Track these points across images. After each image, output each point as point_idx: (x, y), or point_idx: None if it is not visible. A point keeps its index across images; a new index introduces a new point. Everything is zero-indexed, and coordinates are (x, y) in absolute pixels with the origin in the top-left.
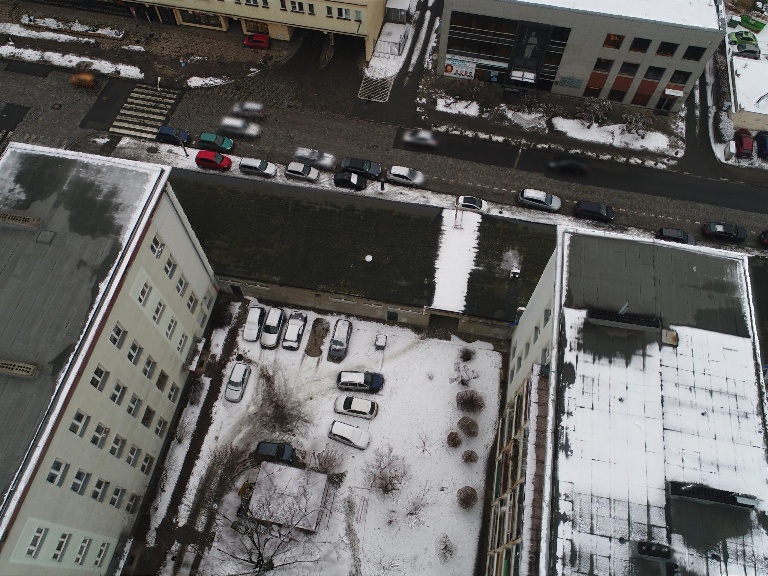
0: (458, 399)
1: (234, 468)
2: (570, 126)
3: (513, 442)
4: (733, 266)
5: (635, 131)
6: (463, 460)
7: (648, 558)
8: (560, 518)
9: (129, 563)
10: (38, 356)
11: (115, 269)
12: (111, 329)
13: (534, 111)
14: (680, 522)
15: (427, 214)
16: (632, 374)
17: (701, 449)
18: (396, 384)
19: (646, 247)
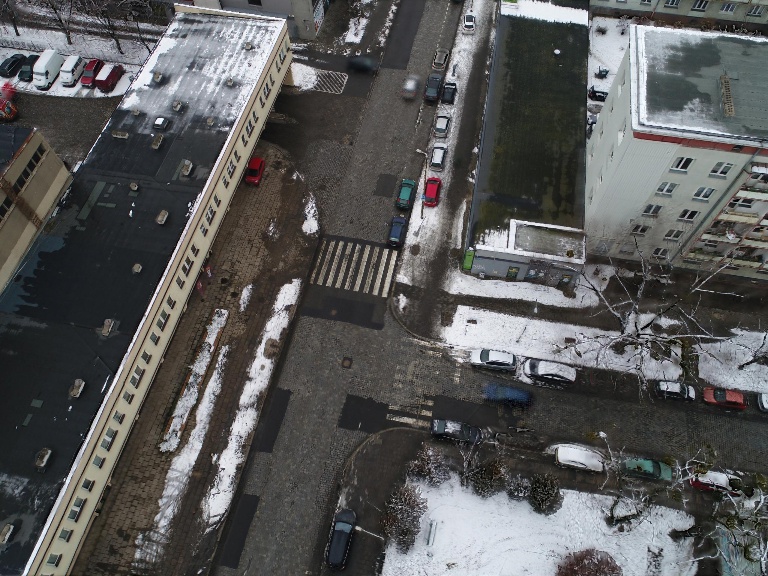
0: None
1: None
2: None
3: None
4: None
5: None
6: None
7: None
8: None
9: None
10: None
11: None
12: None
13: None
14: None
15: (507, 23)
16: None
17: None
18: None
19: None
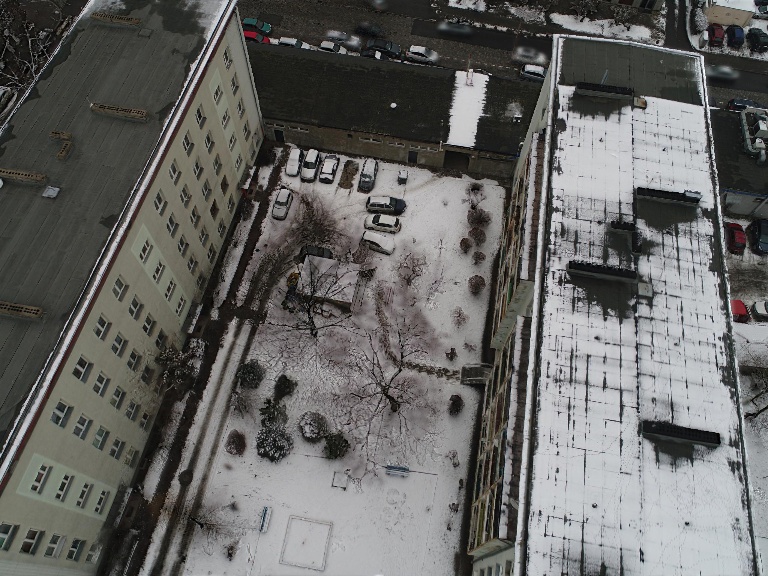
0: (469, 216)
1: (281, 267)
2: (565, 20)
3: (516, 208)
4: (692, 61)
5: (622, 23)
6: (473, 262)
7: (619, 232)
8: (553, 210)
9: (197, 331)
10: (147, 108)
11: (202, 56)
12: (197, 107)
13: (534, 8)
14: (643, 212)
15: (442, 74)
16: (610, 125)
17: (661, 170)
18: (416, 209)
19: (623, 47)
